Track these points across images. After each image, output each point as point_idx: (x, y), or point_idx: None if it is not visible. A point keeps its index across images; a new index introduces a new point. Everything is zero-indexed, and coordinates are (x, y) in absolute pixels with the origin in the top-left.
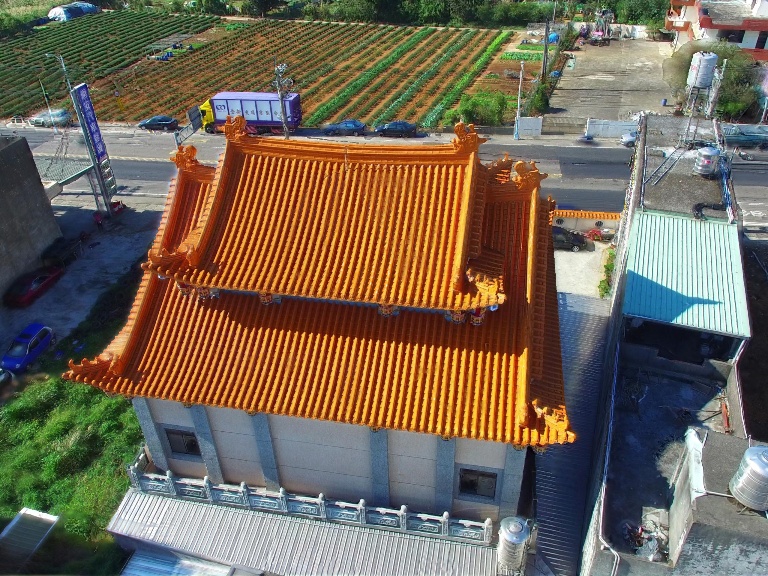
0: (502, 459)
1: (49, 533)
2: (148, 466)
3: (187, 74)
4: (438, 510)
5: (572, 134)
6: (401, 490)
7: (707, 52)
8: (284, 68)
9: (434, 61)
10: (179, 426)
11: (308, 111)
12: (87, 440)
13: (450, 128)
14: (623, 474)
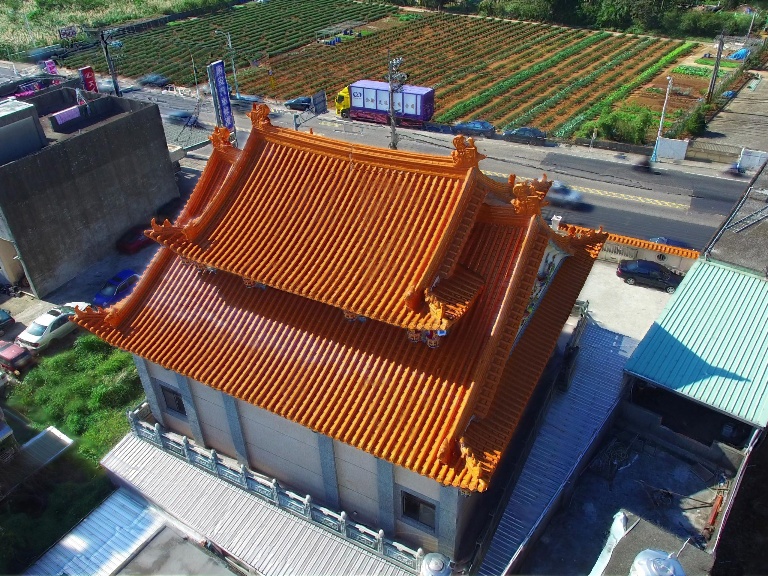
0: (439, 491)
1: (61, 453)
2: (151, 415)
3: (346, 60)
4: (382, 526)
5: (721, 163)
6: (350, 496)
7: None
8: (399, 62)
9: (595, 68)
10: (170, 385)
11: (445, 107)
12: (132, 381)
13: (583, 141)
14: (560, 542)
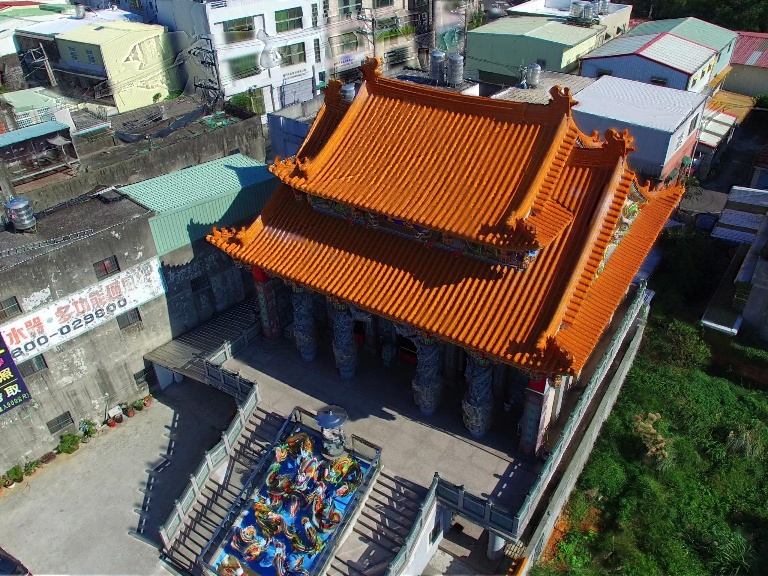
0: None
1: None
2: None
3: None
4: None
5: None
6: None
7: None
8: None
9: None
10: None
11: None
12: None
13: None
14: None
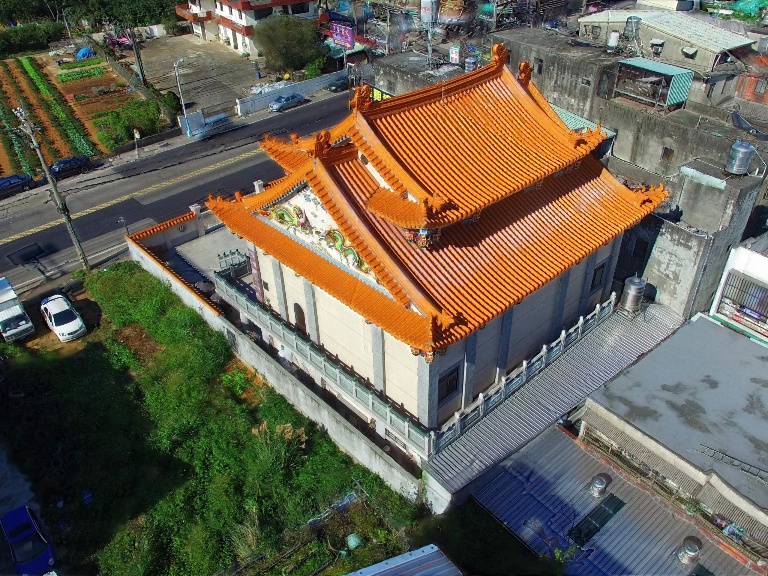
0: (611, 248)
1: None
2: None
3: None
4: (581, 314)
5: None
6: (564, 315)
7: None
8: None
9: None
10: (451, 367)
11: None
12: (259, 523)
13: (121, 148)
14: None
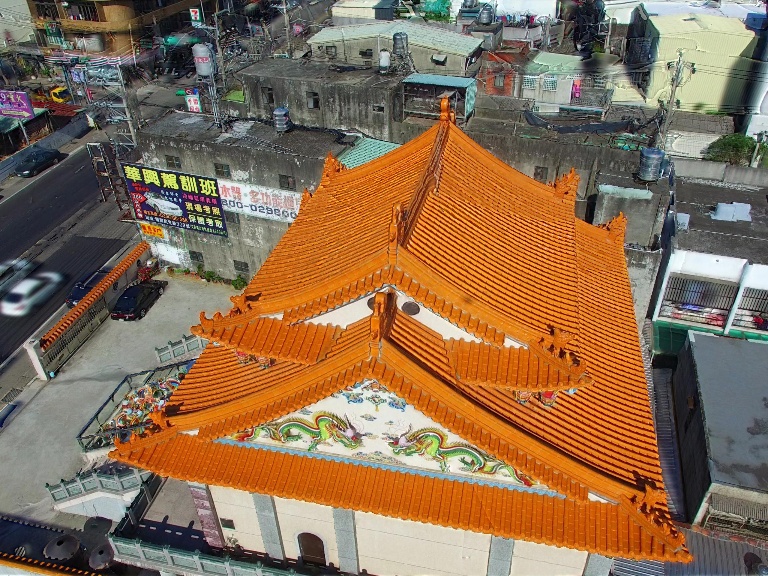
0: None
1: None
2: None
3: None
4: None
5: None
6: None
7: (201, 43)
8: None
9: None
10: None
11: None
12: None
13: None
14: None
